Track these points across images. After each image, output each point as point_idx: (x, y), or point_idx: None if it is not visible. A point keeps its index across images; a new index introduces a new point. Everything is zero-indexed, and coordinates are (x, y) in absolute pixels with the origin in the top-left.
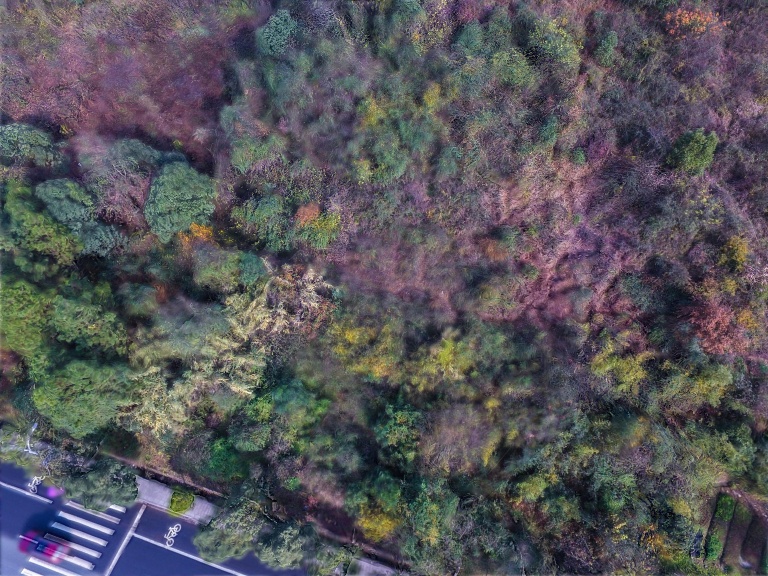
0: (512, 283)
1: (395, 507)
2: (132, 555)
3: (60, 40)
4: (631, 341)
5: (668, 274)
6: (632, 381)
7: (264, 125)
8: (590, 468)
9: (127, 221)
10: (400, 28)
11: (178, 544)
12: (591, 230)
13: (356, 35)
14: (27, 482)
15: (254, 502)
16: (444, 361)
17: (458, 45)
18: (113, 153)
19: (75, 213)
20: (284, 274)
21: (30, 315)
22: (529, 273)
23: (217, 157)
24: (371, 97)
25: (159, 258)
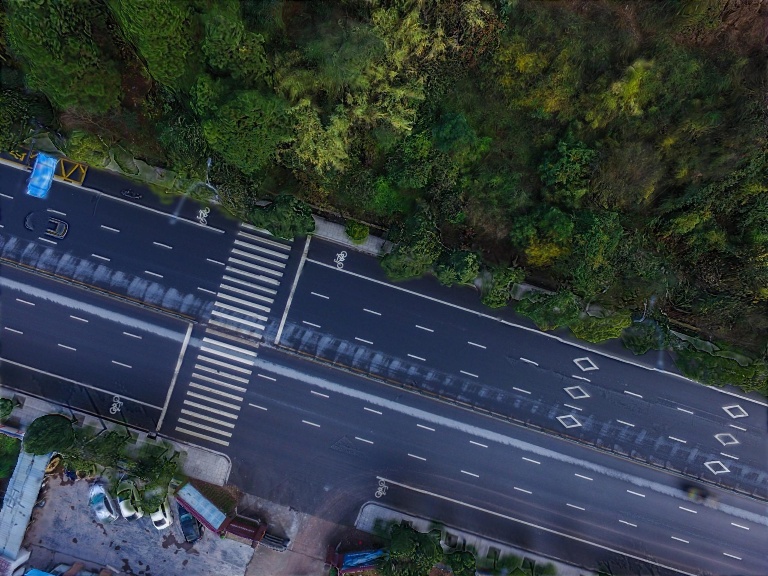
0: None
1: (567, 237)
2: (310, 275)
3: None
4: None
5: None
6: None
7: None
8: (748, 206)
9: None
10: None
11: (347, 267)
12: None
13: None
14: (195, 215)
15: (431, 232)
16: (628, 94)
17: None
18: None
19: None
20: None
21: (171, 33)
22: None
23: None
24: None
25: None
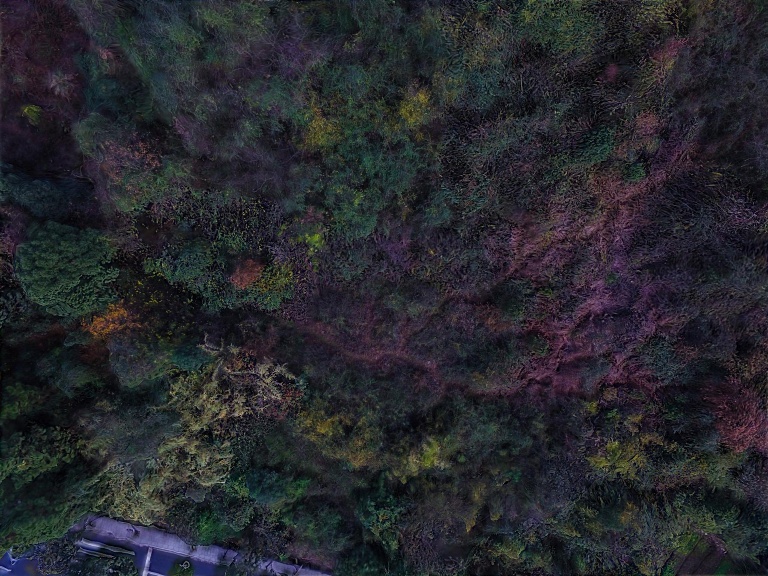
0: (514, 368)
1: None
2: None
3: None
4: (642, 425)
5: (710, 347)
6: (631, 465)
7: (150, 135)
8: (569, 536)
9: (8, 283)
10: None
11: None
12: (628, 277)
13: None
14: None
15: None
16: (429, 461)
17: None
18: None
19: None
20: (232, 363)
21: None
22: (537, 351)
23: None
24: (313, 105)
25: None
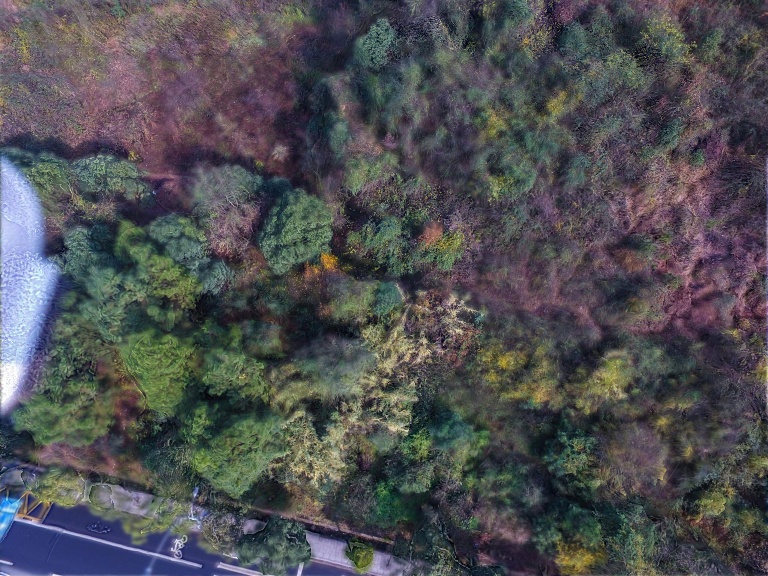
0: (658, 294)
1: (598, 541)
2: None
3: (108, 58)
4: None
5: None
6: None
7: (372, 143)
8: (767, 478)
9: (236, 254)
10: (511, 34)
11: None
12: (718, 233)
13: (459, 42)
14: (169, 547)
15: (445, 550)
16: (609, 381)
17: (567, 49)
18: (212, 182)
19: (192, 251)
20: (422, 301)
21: (175, 370)
22: (671, 282)
23: (323, 179)
24: (491, 108)
25: (268, 290)
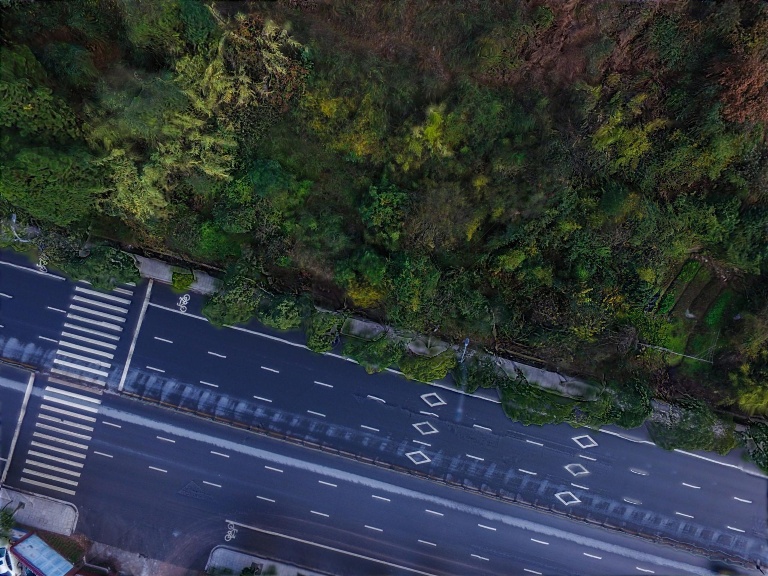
0: (519, 34)
1: (381, 282)
2: (153, 319)
3: None
4: (644, 107)
5: (714, 16)
6: (633, 154)
7: None
8: (570, 241)
9: None
10: None
11: (191, 310)
12: None
13: None
14: (34, 263)
15: (250, 280)
16: (432, 137)
17: None
18: None
19: None
20: (239, 28)
21: None
22: (541, 19)
23: None
24: None
25: (81, 5)
